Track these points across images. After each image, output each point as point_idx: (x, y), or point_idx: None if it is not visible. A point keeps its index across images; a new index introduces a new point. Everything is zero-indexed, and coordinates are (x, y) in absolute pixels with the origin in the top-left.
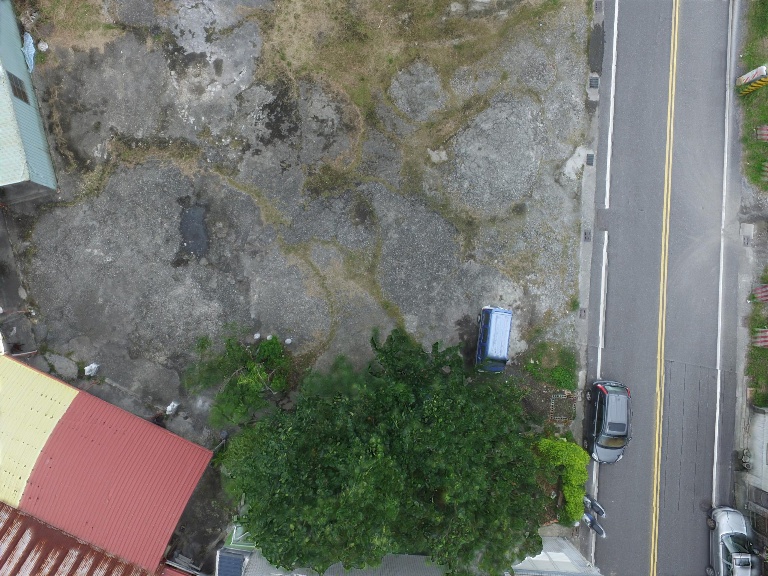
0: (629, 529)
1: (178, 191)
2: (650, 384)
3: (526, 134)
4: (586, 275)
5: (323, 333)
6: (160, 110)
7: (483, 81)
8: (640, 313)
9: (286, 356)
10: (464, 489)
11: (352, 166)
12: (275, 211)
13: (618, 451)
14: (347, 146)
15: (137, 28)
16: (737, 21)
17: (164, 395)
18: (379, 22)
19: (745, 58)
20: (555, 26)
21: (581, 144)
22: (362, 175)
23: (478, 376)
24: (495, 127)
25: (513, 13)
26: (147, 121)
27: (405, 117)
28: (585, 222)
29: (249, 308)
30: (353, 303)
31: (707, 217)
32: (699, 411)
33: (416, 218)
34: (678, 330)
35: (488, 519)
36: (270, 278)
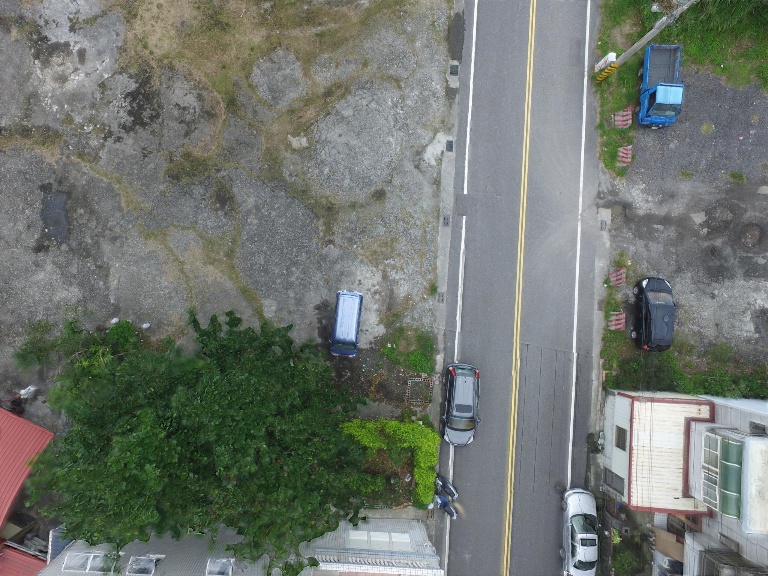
0: (484, 511)
1: (40, 178)
2: (506, 367)
3: (386, 121)
4: (444, 260)
5: (182, 318)
6: (23, 98)
7: (344, 69)
8: (497, 297)
9: (145, 340)
10: (235, 460)
11: (213, 153)
12: (136, 197)
13: (468, 433)
14: (208, 133)
15: (1, 18)
16: (596, 9)
17: (23, 379)
18: (241, 11)
19: (603, 45)
20: (416, 15)
21: (441, 130)
22: (223, 162)
23: (336, 360)
24: (355, 114)
25: (374, 2)
26: (10, 109)
27: (266, 104)
28: (444, 207)
29: (109, 293)
30: (212, 288)
31: (564, 202)
32: (555, 394)
33: (276, 204)
34: (535, 314)
35: (268, 491)
36: (130, 263)
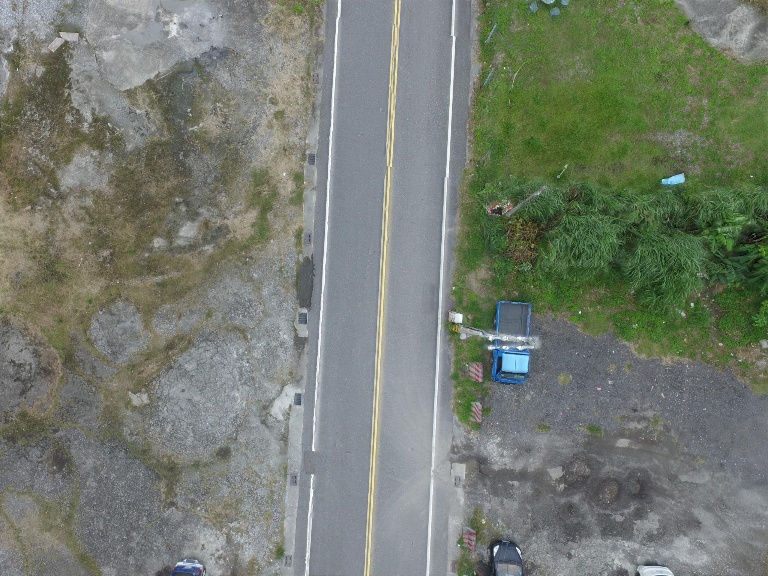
0: None
1: None
2: None
3: (231, 374)
4: (292, 521)
5: None
6: None
7: (187, 320)
8: (346, 561)
9: None
10: None
11: (50, 412)
12: None
13: None
14: (45, 391)
15: None
16: (450, 252)
17: None
18: (79, 260)
19: (456, 291)
20: (262, 260)
21: (289, 383)
22: (61, 421)
23: None
24: (199, 367)
25: (218, 248)
26: None
27: (105, 359)
28: (292, 465)
29: None
30: (49, 556)
31: (416, 458)
32: None
33: (116, 465)
34: None
35: None
36: None
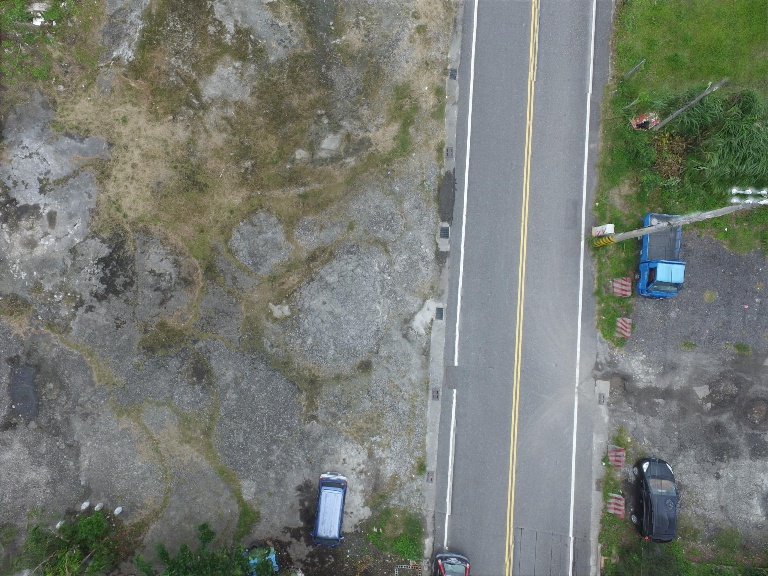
0: None
1: (7, 350)
2: (499, 553)
3: (372, 287)
4: (434, 436)
5: (156, 500)
6: None
7: (328, 232)
8: (489, 477)
9: (117, 525)
10: None
11: (190, 322)
12: (108, 371)
13: None
14: (185, 301)
15: None
16: (593, 167)
17: None
18: (221, 171)
19: (600, 207)
20: (404, 174)
21: (430, 297)
22: (200, 332)
23: (319, 545)
24: (340, 280)
25: (360, 160)
26: None
27: (246, 270)
28: (433, 380)
29: (79, 474)
30: (188, 468)
31: (560, 374)
32: None
33: (256, 377)
34: (529, 495)
35: None
36: (102, 442)
